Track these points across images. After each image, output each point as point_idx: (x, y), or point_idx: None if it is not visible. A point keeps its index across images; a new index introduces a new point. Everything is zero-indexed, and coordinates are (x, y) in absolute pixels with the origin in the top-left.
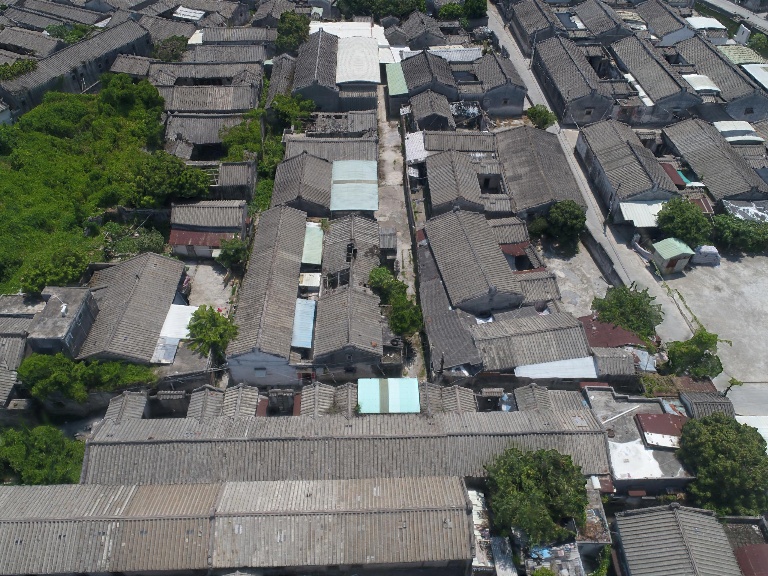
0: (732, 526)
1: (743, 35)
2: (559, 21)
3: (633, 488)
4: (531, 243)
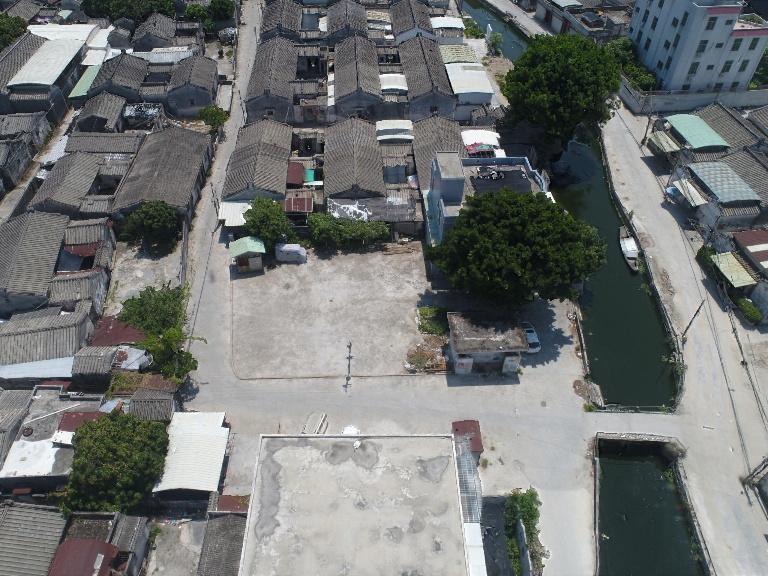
0: (88, 522)
1: (489, 34)
2: (299, 22)
3: (19, 486)
4: (132, 243)
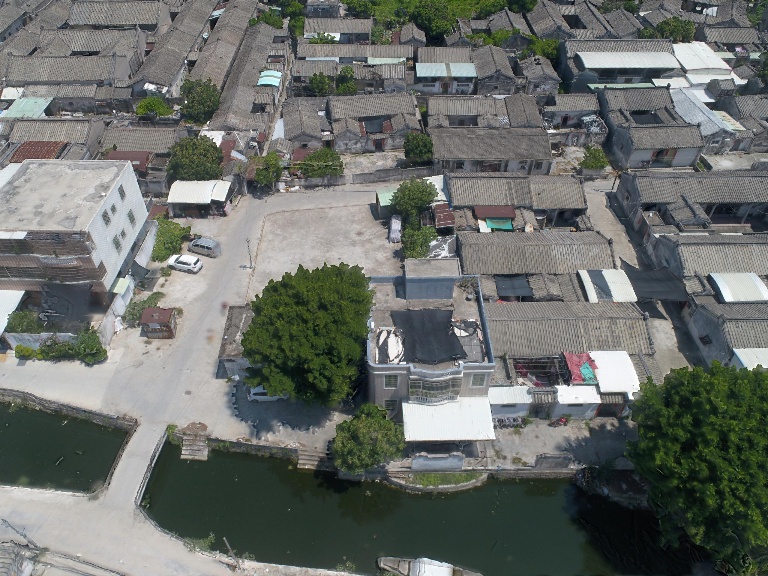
0: None
1: None
2: None
3: None
4: None
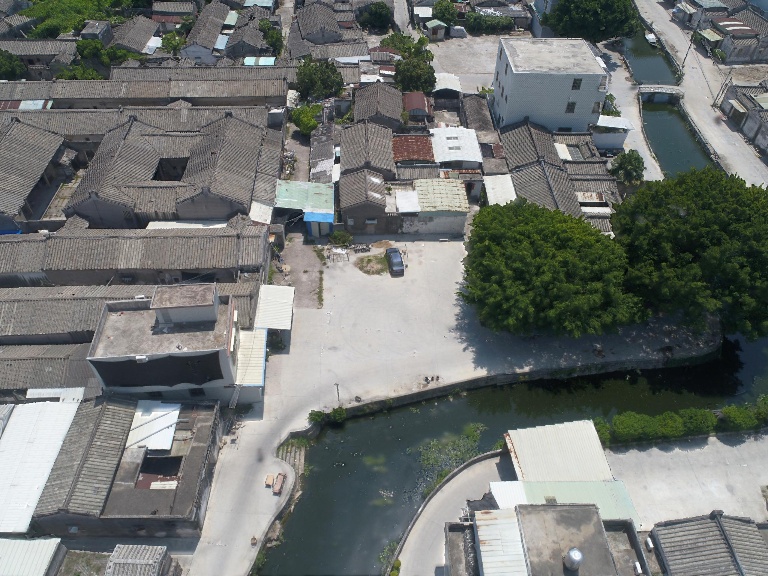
0: None
1: None
2: None
3: None
4: (362, 30)
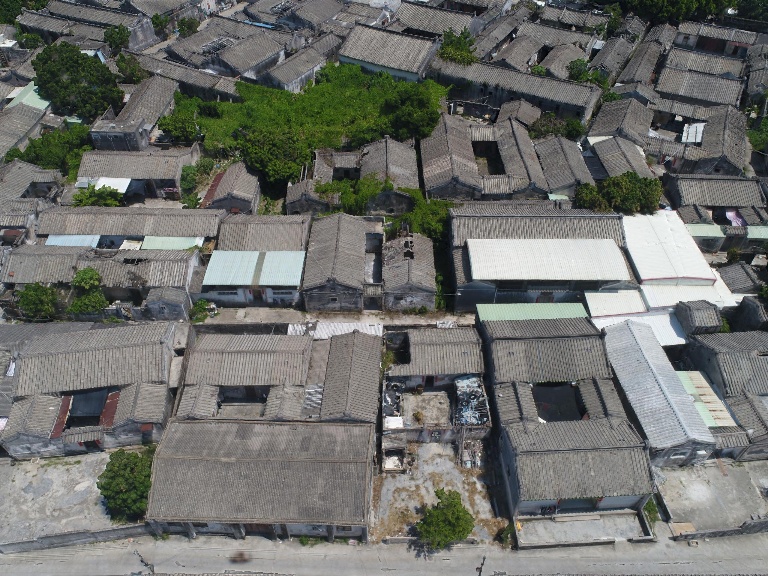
0: None
1: None
2: None
3: None
4: None
